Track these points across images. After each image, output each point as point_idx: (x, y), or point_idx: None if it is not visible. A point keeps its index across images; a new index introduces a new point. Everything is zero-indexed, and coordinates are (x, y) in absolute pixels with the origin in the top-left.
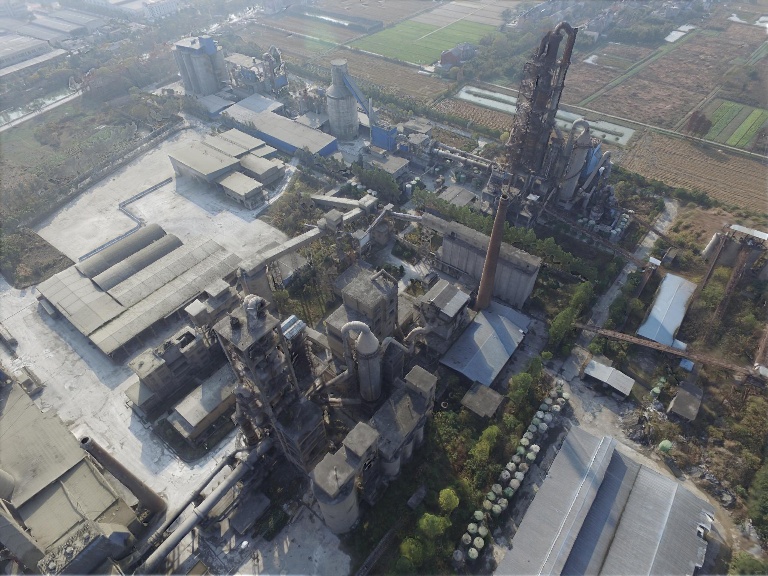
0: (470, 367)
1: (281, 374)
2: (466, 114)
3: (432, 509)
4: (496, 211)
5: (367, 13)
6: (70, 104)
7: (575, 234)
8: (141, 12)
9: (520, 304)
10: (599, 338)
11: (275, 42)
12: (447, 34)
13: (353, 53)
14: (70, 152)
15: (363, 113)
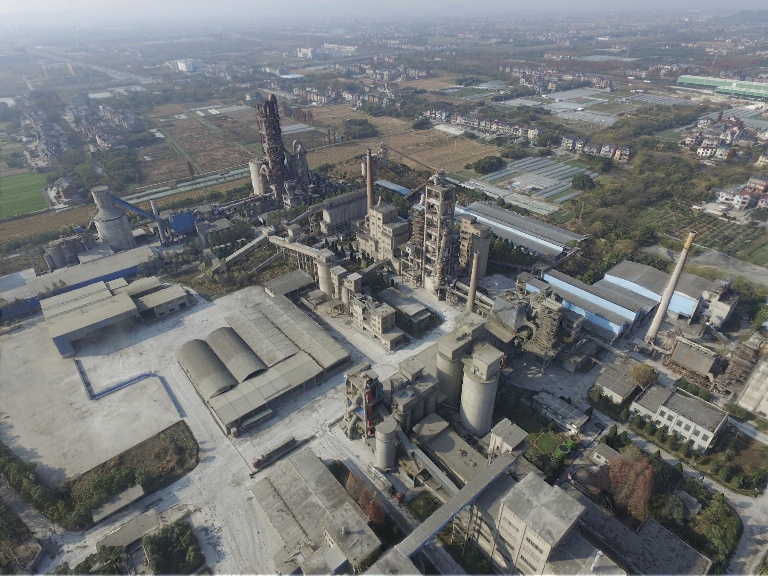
0: None
1: None
2: None
3: None
4: None
5: None
6: None
7: None
8: None
9: None
10: None
11: None
12: None
13: None
14: None
15: None
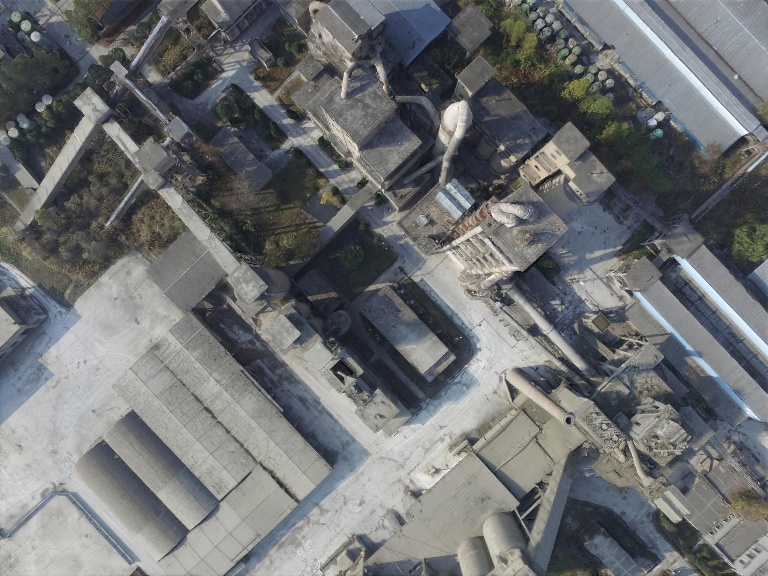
0: (423, 31)
1: None
2: None
3: (560, 115)
4: None
5: None
6: None
7: None
8: None
9: None
10: None
11: None
12: None
13: None
14: None
15: None
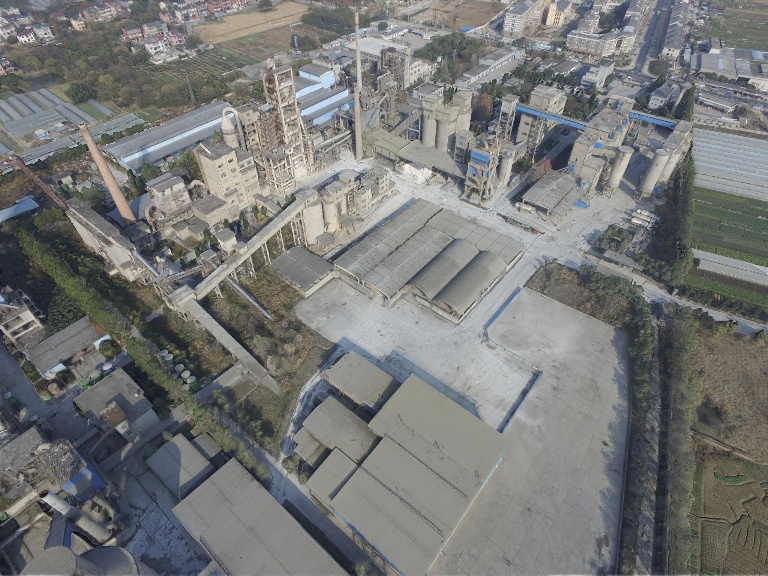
0: None
1: None
2: None
3: None
4: None
5: None
6: None
7: None
8: None
9: None
10: None
11: None
12: None
13: None
14: None
15: None
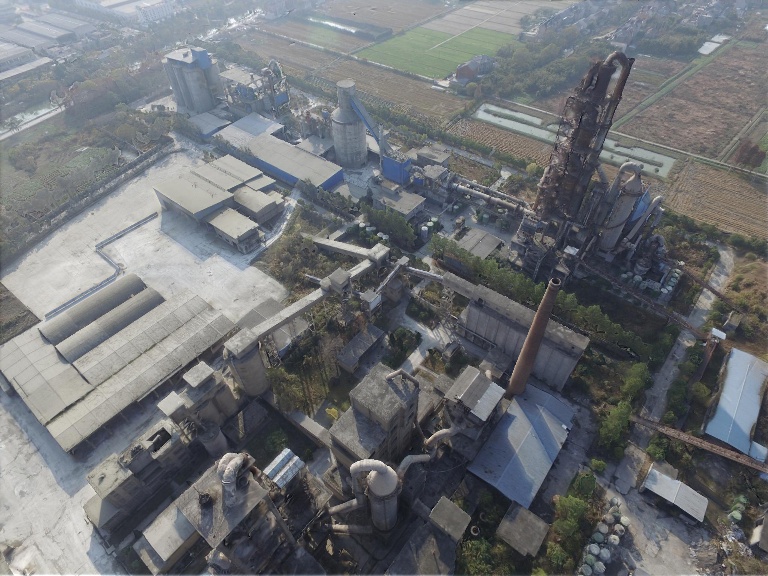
0: (505, 479)
1: (271, 537)
2: (486, 138)
3: None
4: (527, 263)
5: (375, 19)
6: (51, 121)
7: (619, 292)
8: (134, 16)
9: (560, 386)
10: (659, 438)
11: (276, 51)
12: (461, 43)
13: (360, 64)
14: (46, 179)
15: (372, 136)
